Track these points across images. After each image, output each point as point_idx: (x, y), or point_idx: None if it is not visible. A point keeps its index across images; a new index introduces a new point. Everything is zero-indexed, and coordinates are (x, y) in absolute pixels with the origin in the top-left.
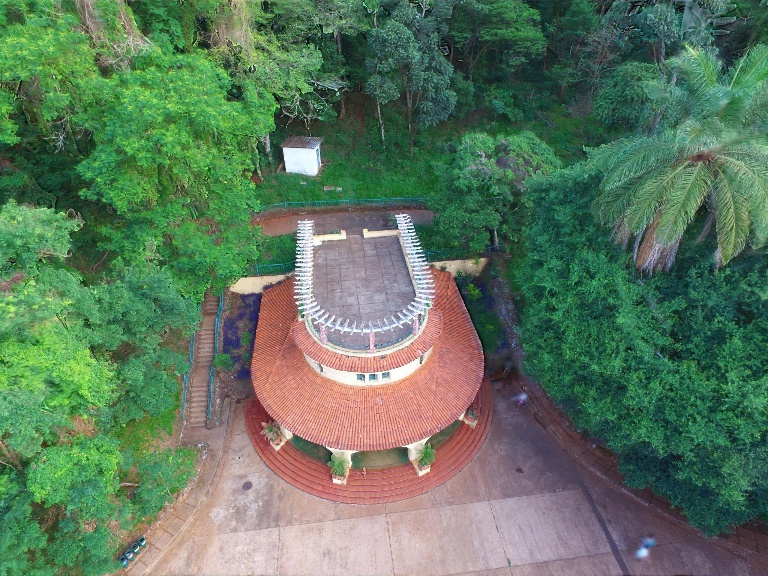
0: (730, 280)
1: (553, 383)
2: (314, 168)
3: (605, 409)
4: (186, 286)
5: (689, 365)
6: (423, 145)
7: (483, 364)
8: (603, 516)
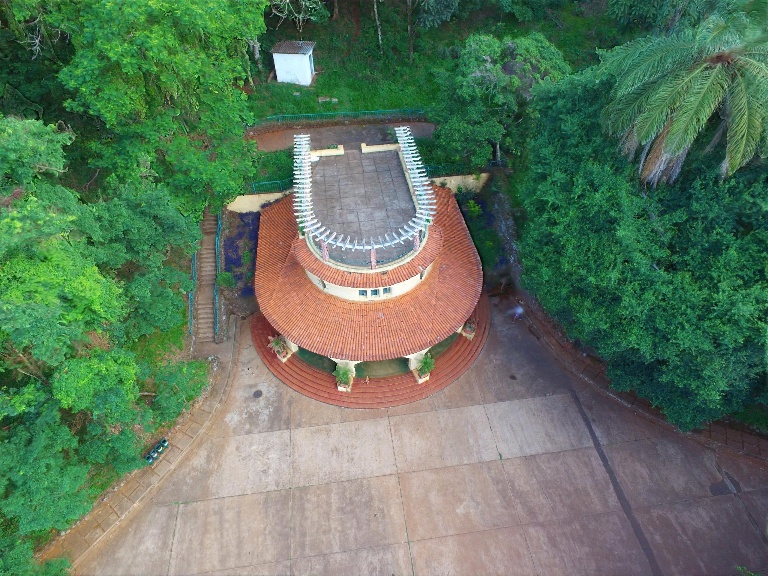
0: (734, 191)
1: (550, 296)
2: (307, 77)
3: (599, 319)
4: (184, 204)
5: (683, 276)
6: (423, 50)
7: (482, 279)
8: (588, 416)
